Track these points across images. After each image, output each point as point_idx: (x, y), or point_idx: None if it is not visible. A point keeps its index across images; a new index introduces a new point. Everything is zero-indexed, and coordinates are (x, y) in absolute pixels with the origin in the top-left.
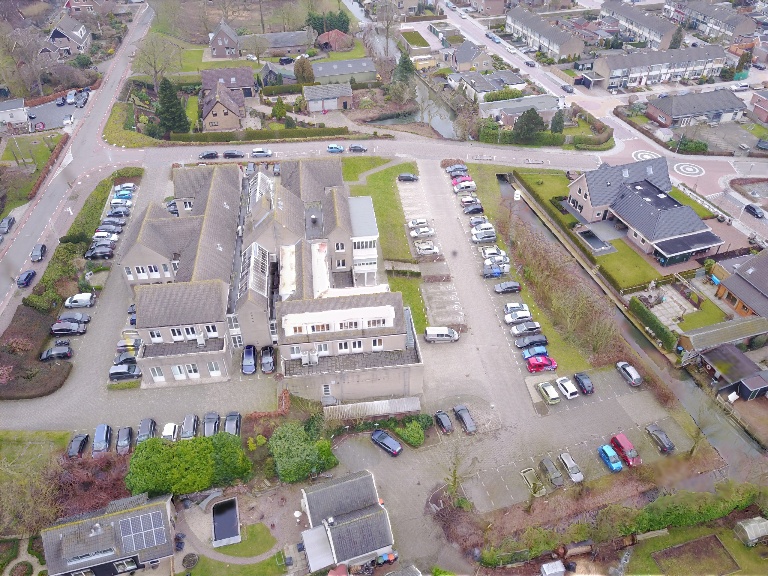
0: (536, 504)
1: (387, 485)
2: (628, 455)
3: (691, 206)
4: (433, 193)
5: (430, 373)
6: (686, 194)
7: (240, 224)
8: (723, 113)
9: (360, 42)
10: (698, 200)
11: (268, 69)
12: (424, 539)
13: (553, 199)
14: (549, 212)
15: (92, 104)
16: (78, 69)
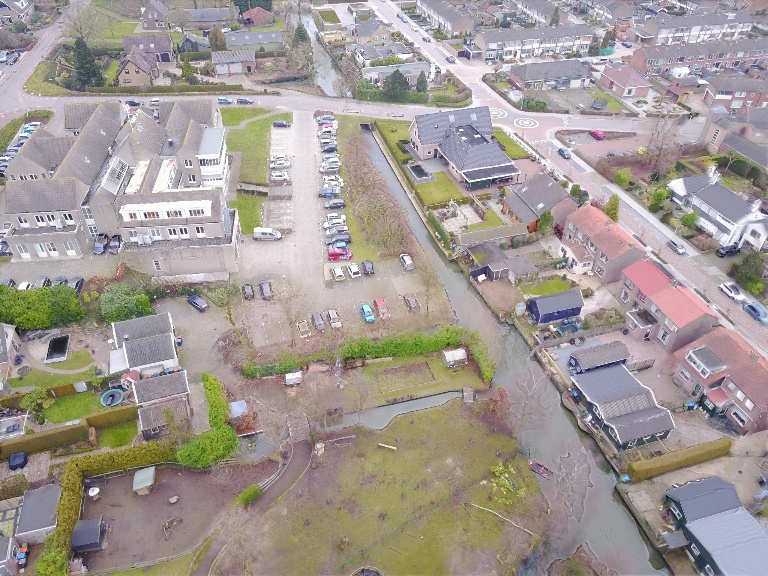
0: (299, 342)
1: (190, 329)
2: (380, 311)
3: (514, 149)
4: (300, 137)
5: (249, 260)
6: (514, 141)
7: (113, 147)
8: (571, 79)
9: (282, 19)
10: (522, 145)
11: (186, 38)
12: (207, 362)
13: (398, 142)
14: (391, 151)
15: (21, 62)
16: (13, 33)
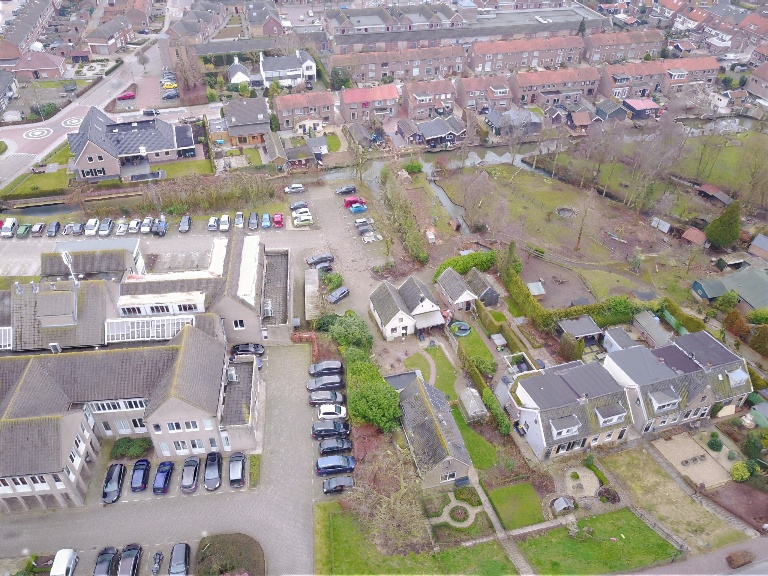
0: None
1: None
2: (359, 200)
3: None
4: None
5: None
6: None
7: None
8: (11, 85)
9: None
10: None
11: None
12: None
13: (73, 183)
14: None
15: None
16: None
